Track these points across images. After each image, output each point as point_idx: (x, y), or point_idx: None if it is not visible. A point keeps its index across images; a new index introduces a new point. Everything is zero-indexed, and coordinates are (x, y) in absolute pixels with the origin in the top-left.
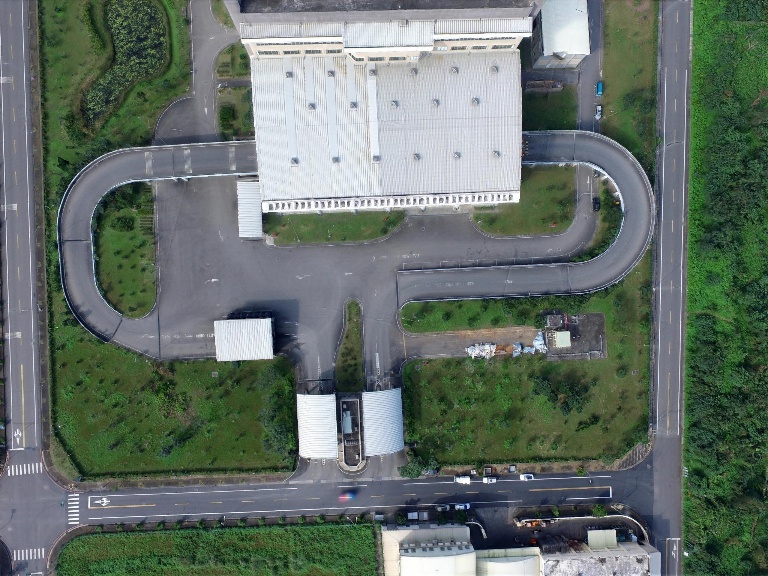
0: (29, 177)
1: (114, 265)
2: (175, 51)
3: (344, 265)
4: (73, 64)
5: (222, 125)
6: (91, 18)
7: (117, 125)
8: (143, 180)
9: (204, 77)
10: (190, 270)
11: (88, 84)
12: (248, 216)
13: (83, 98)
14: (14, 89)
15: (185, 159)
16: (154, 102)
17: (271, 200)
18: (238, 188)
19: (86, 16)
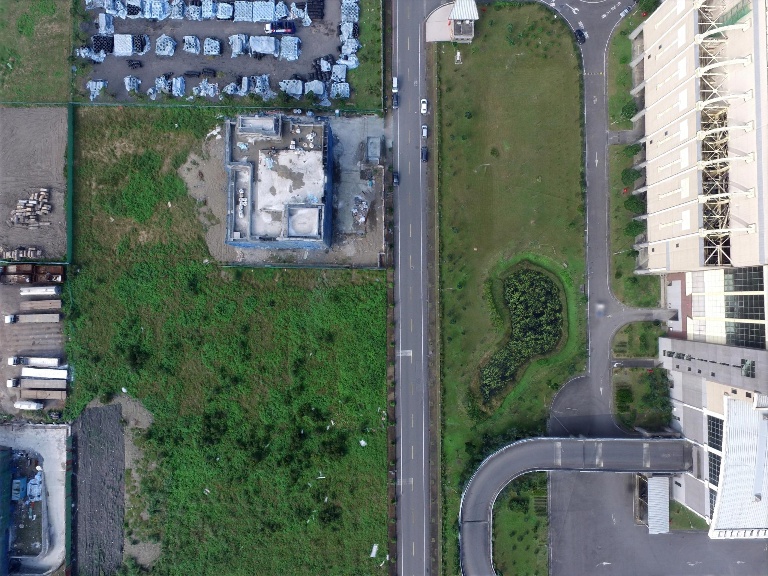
0: (425, 451)
1: (508, 545)
2: (571, 328)
3: (736, 553)
4: (471, 339)
5: (620, 407)
6: (492, 295)
7: (514, 403)
8: (551, 470)
9: (600, 356)
10: (582, 552)
11: (485, 360)
12: (658, 512)
13: (480, 374)
14: (412, 363)
15: (596, 452)
16: (551, 381)
17: (722, 529)
18: (649, 484)
19: (489, 294)
